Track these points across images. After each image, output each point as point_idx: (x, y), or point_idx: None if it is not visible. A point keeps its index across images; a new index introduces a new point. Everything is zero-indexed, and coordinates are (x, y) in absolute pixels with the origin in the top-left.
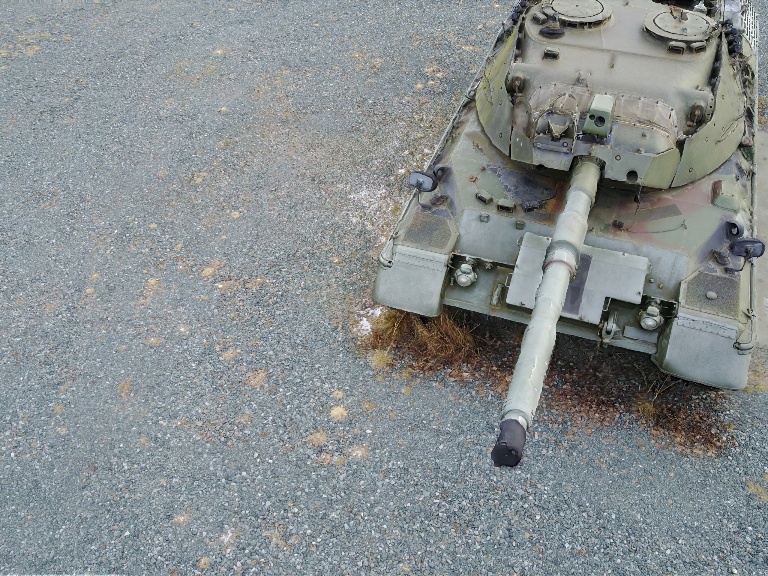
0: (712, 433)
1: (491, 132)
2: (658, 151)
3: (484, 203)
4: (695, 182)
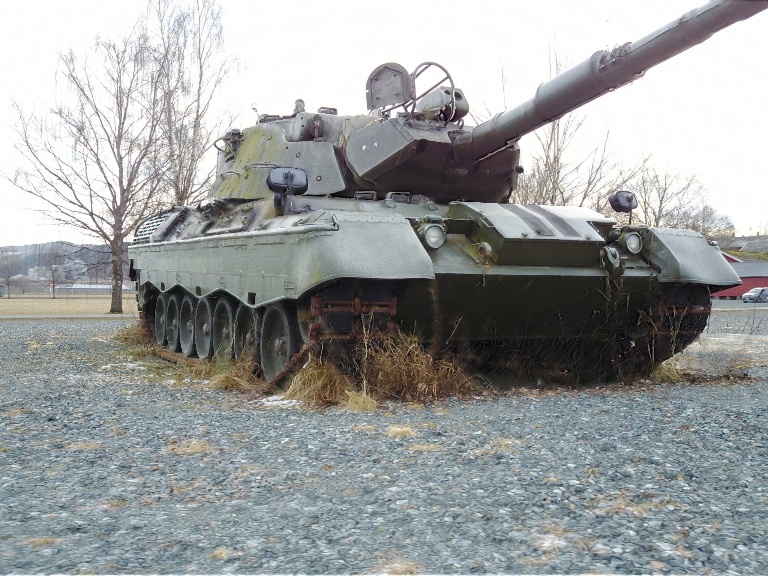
0: None
1: None
2: None
3: None
4: None
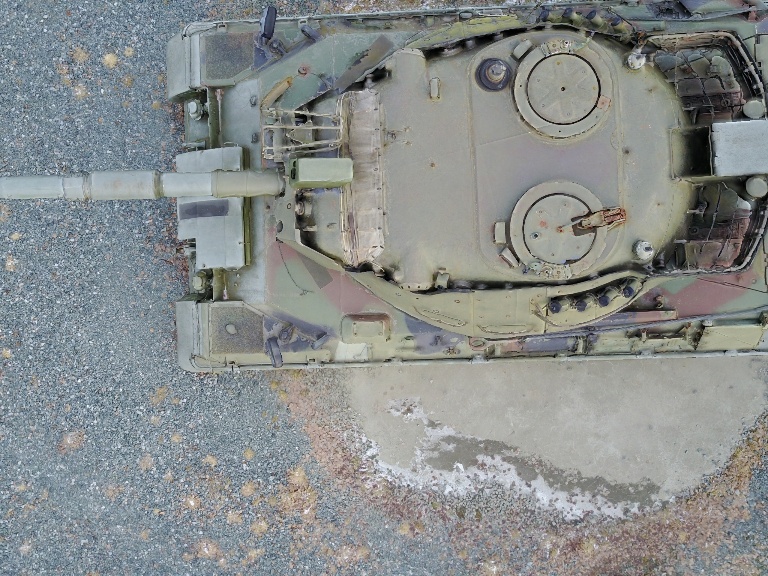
0: None
1: None
2: (320, 244)
3: None
4: None
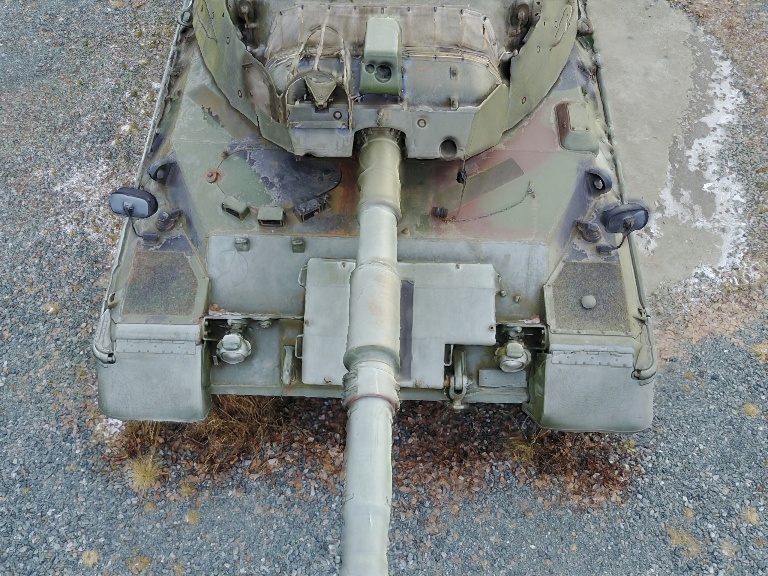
0: (611, 463)
1: (225, 87)
2: (477, 96)
3: (237, 218)
4: (531, 113)
